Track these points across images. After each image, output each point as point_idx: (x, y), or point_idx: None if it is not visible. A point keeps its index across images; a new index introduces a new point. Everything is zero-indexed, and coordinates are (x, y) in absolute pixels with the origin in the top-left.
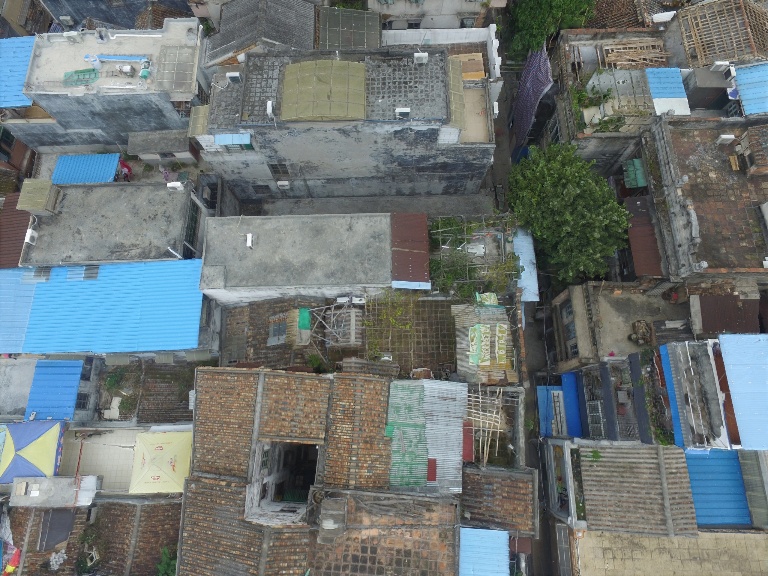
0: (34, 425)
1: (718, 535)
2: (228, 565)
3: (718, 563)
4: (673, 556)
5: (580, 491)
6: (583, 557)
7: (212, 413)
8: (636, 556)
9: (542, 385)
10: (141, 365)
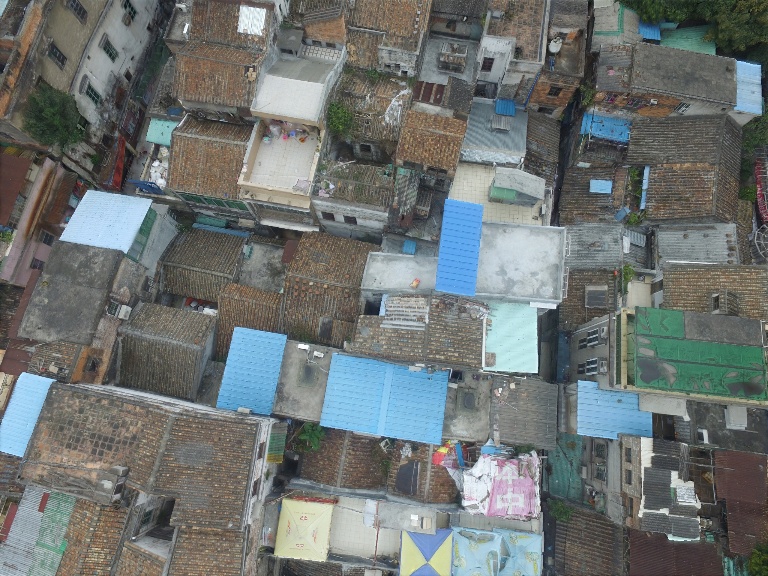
0: None
1: None
2: (196, 462)
3: None
4: None
5: None
6: (2, 393)
7: None
8: None
9: None
10: None
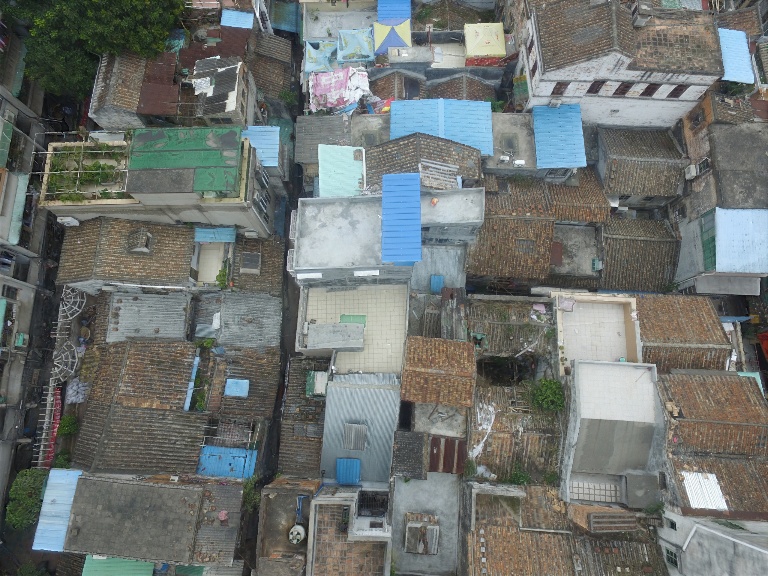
0: (394, 19)
1: None
2: None
3: None
4: None
5: (760, 71)
6: None
7: None
8: None
9: None
10: (445, 2)
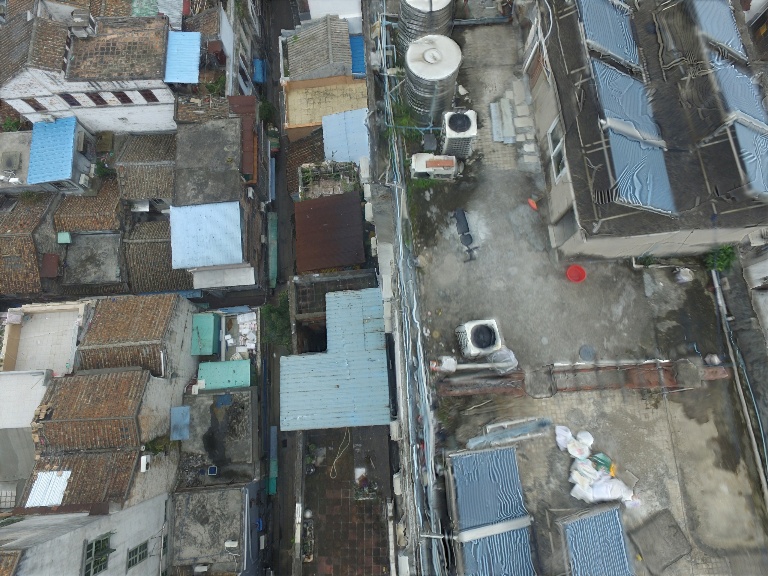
0: None
1: None
2: None
3: None
4: (352, 97)
5: (288, 64)
6: (294, 105)
7: (15, 0)
8: (328, 100)
9: None
10: None
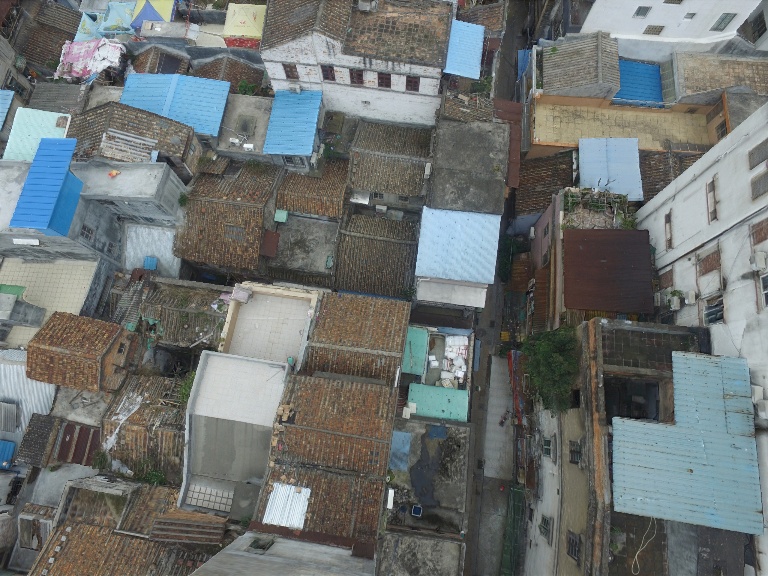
0: None
1: (638, 114)
2: None
3: (636, 129)
4: (604, 123)
5: (541, 75)
6: (539, 120)
7: None
8: (577, 122)
9: (522, 49)
10: None
